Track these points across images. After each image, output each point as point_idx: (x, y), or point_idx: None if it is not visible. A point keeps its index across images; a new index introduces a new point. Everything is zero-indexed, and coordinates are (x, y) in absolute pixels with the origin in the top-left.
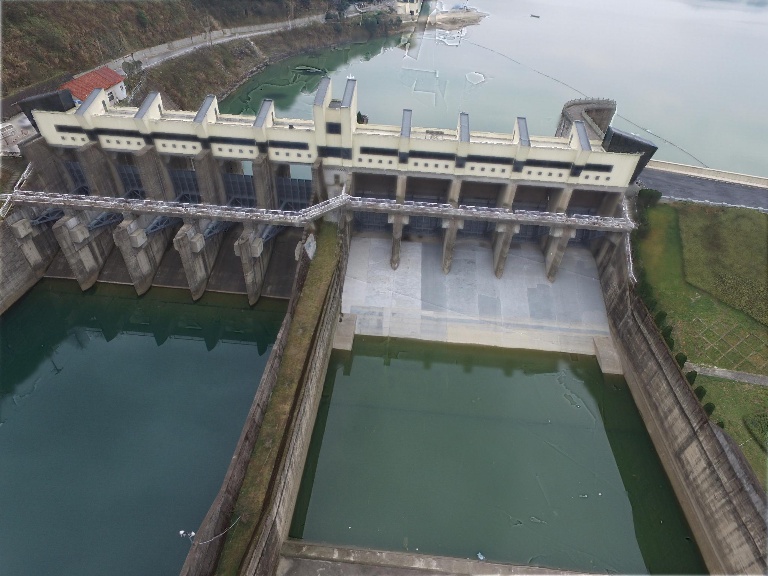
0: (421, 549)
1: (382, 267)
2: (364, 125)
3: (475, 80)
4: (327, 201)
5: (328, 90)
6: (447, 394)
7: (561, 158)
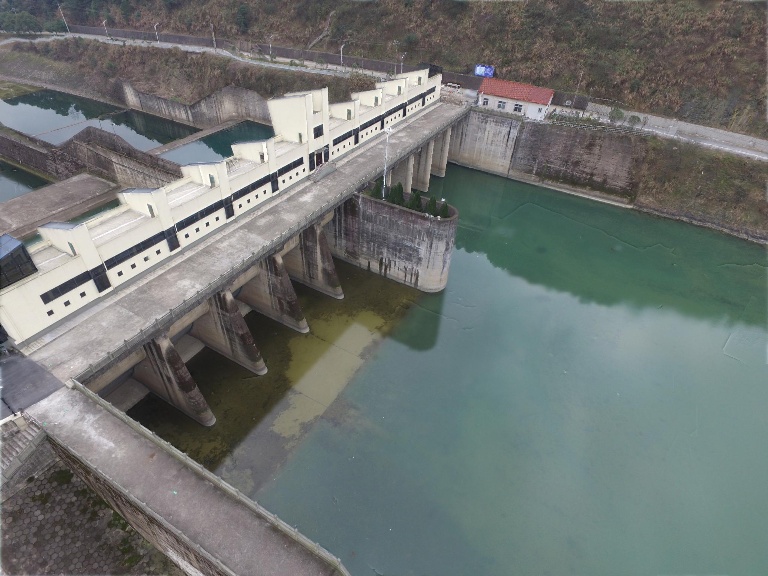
0: (69, 221)
1: None
2: (302, 145)
3: None
4: None
5: (306, 93)
6: None
7: None
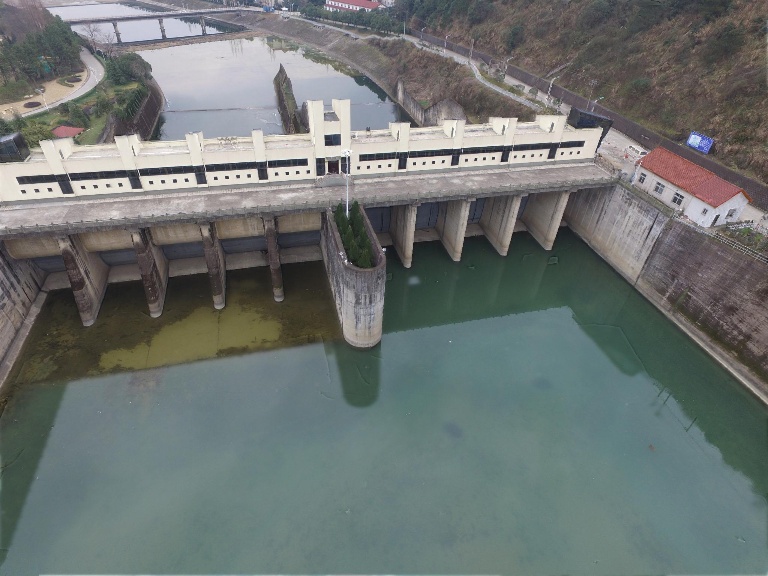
0: None
1: None
2: (307, 147)
3: None
4: None
5: None
6: None
7: None
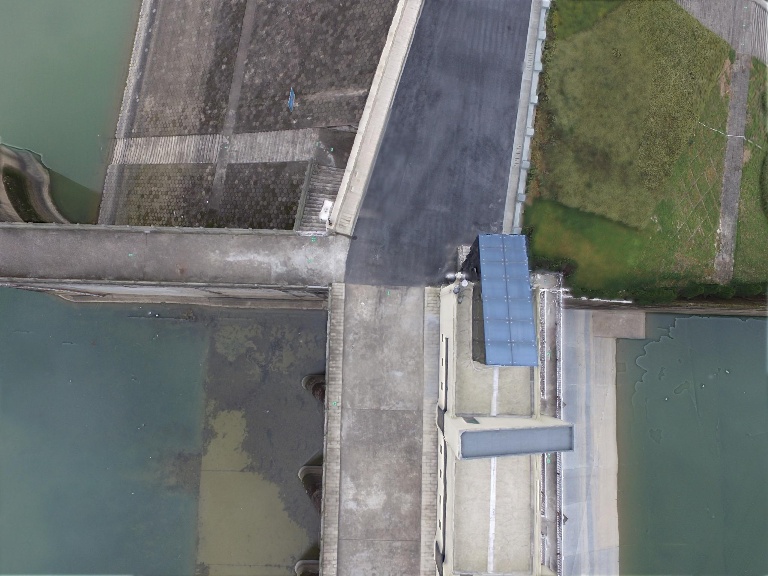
0: None
1: None
2: None
3: None
4: None
5: None
6: (703, 548)
7: None
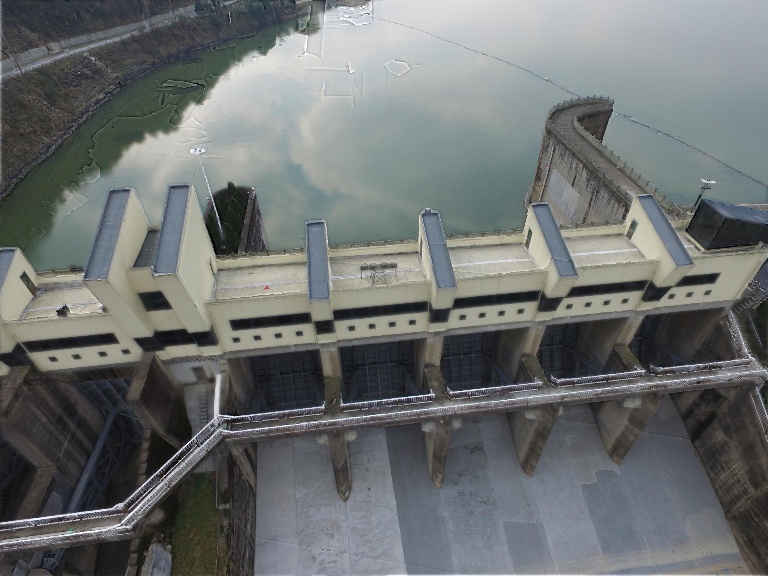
0: None
1: (322, 499)
2: (233, 261)
3: (398, 71)
4: (178, 452)
5: (125, 225)
6: None
7: (628, 276)
